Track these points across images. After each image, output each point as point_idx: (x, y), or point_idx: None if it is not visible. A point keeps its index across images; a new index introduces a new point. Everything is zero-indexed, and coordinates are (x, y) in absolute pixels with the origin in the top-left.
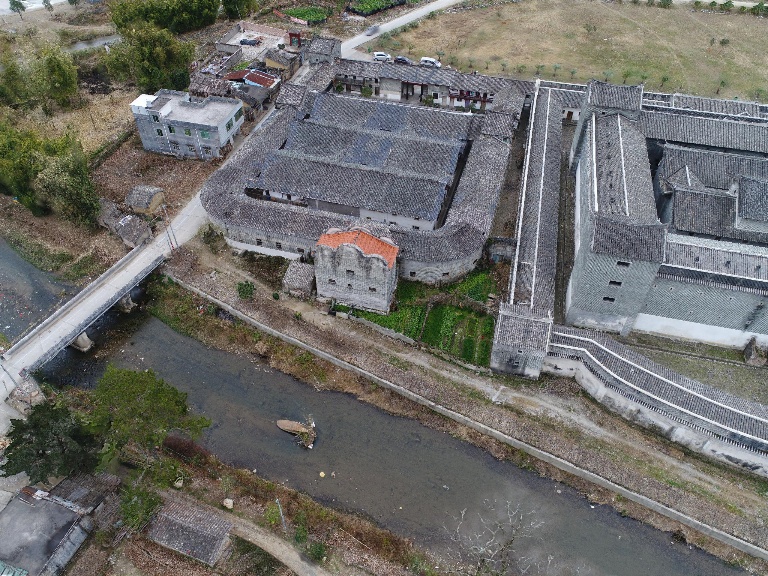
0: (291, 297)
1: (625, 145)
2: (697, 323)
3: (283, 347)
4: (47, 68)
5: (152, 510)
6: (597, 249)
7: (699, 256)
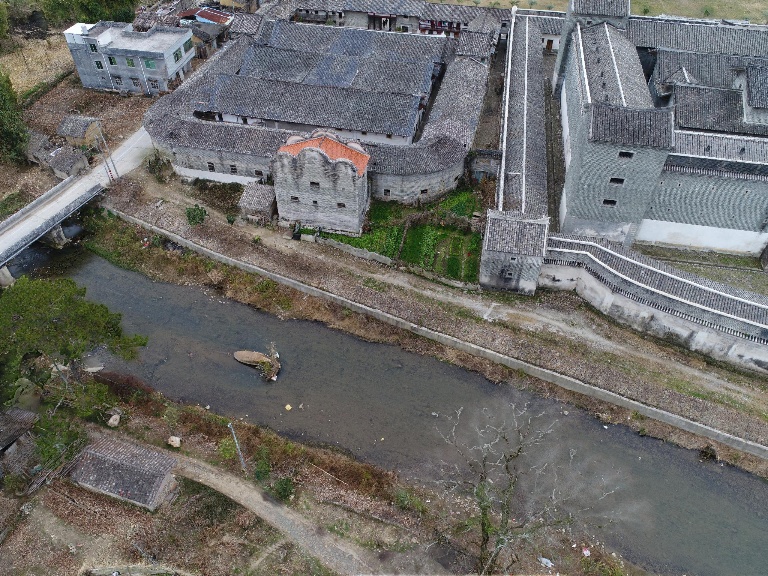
0: (249, 223)
1: (615, 49)
2: (708, 227)
3: (241, 276)
4: None
5: (79, 452)
6: (596, 137)
7: (709, 146)
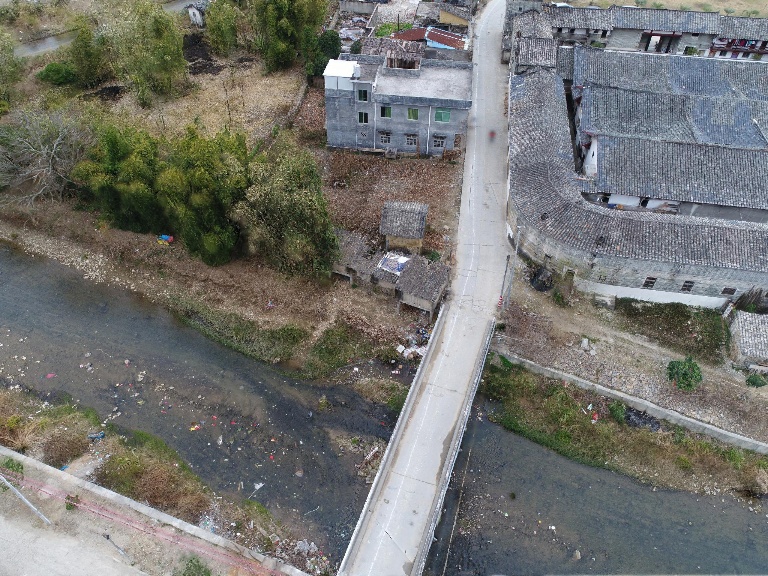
0: None
1: None
2: None
3: None
4: (152, 32)
5: None
6: None
7: None
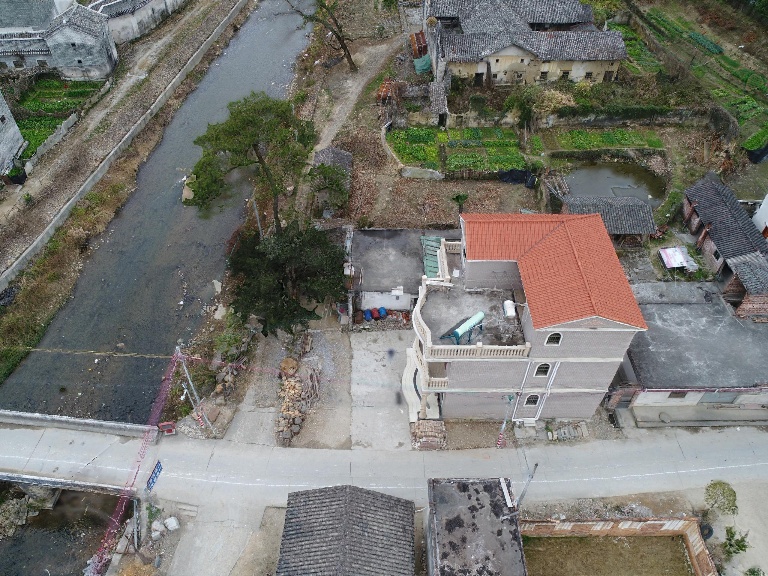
0: None
1: None
2: None
3: None
4: None
5: None
6: None
7: None
